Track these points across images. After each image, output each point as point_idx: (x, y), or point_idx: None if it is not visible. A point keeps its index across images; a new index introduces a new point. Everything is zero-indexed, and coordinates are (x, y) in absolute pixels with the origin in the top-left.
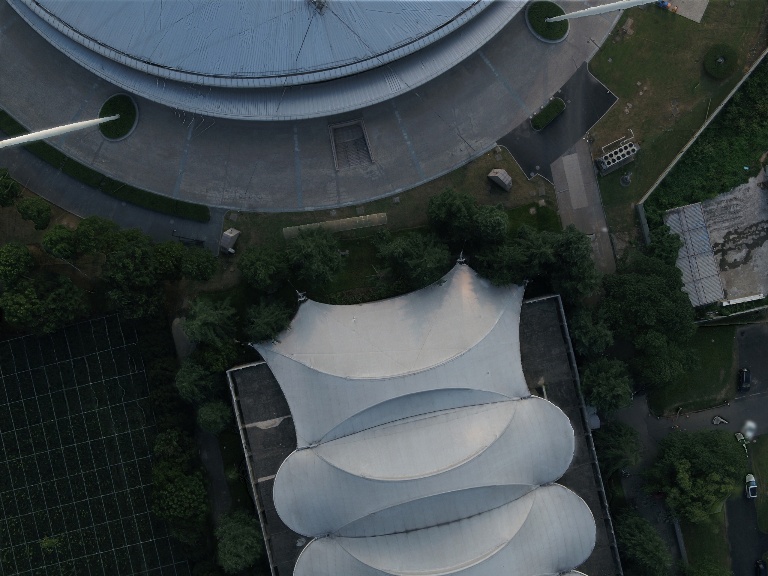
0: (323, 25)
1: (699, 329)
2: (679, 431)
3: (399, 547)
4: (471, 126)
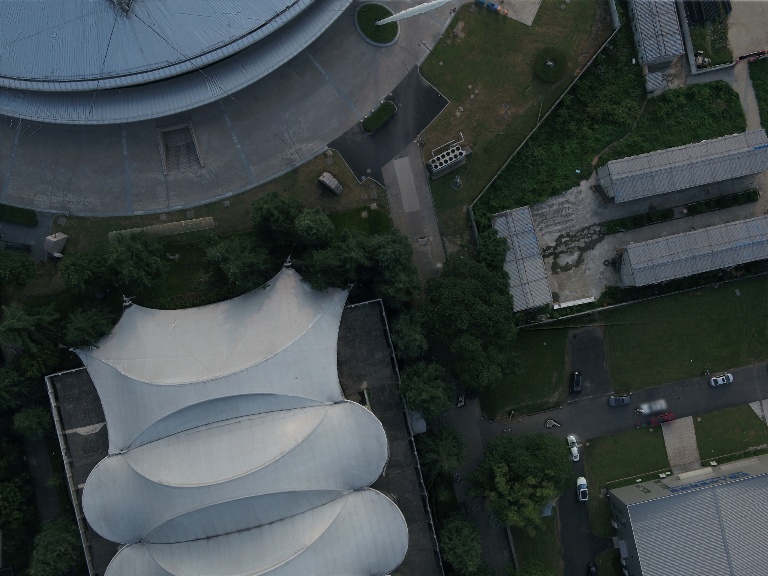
0: (131, 28)
1: (531, 332)
2: (506, 435)
3: (199, 553)
4: (301, 129)
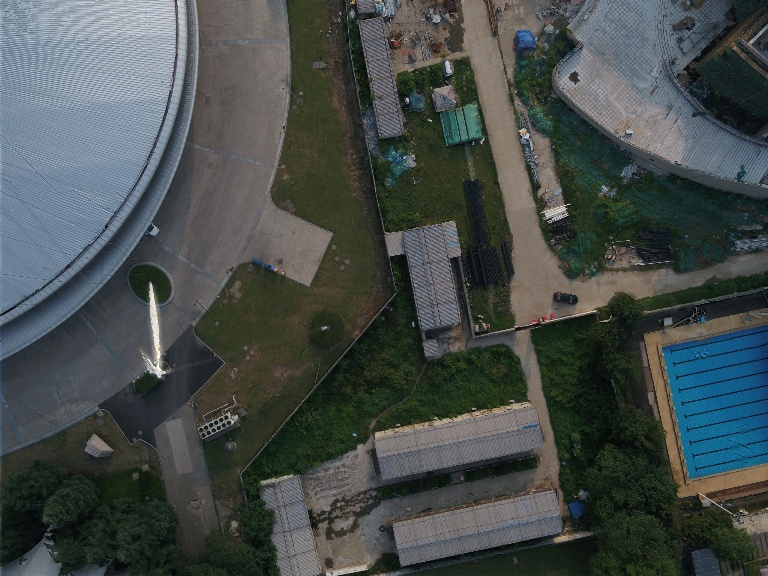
0: None
1: None
2: None
3: None
4: (72, 390)
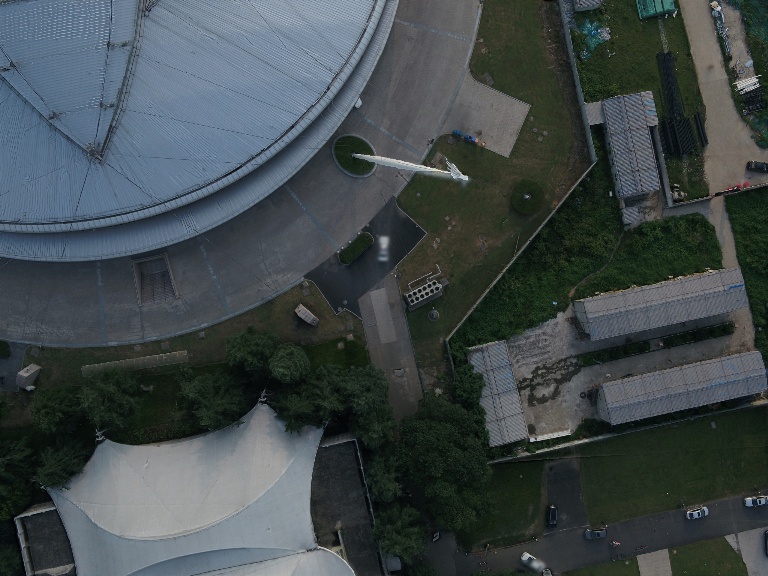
0: (105, 174)
1: (507, 465)
2: (481, 572)
3: None
4: (278, 260)
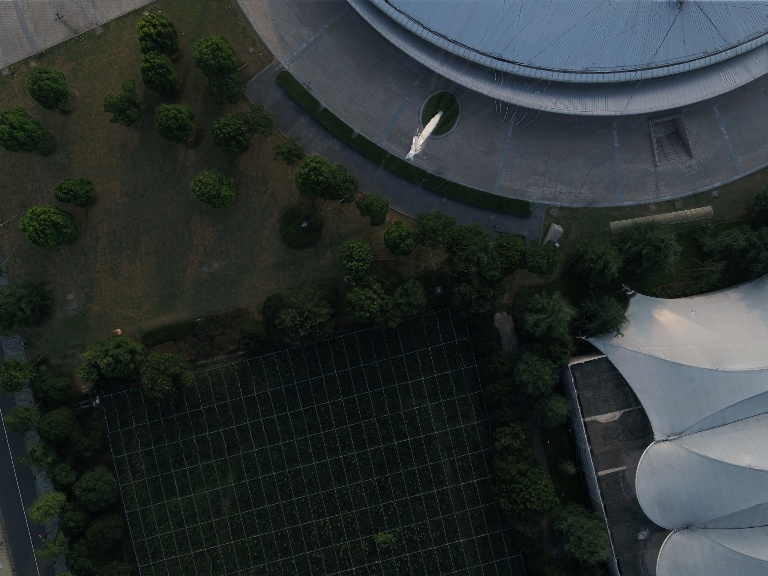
0: (680, 20)
1: None
2: None
3: None
4: None
